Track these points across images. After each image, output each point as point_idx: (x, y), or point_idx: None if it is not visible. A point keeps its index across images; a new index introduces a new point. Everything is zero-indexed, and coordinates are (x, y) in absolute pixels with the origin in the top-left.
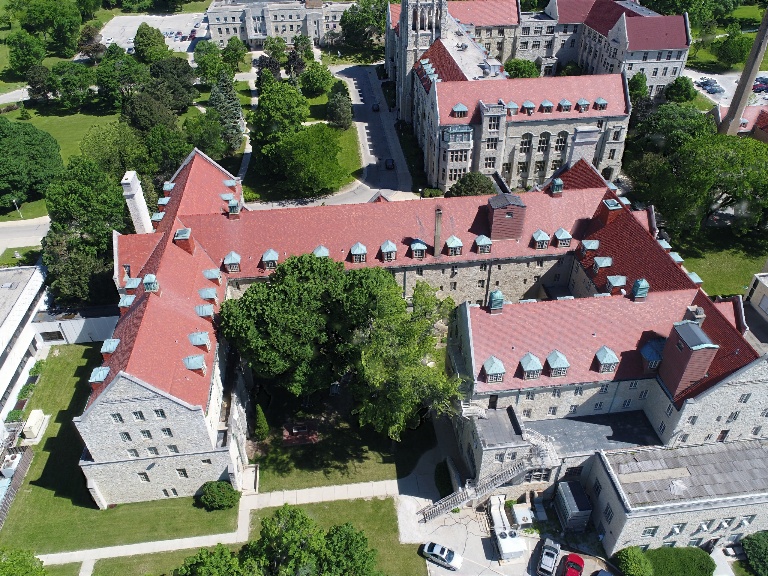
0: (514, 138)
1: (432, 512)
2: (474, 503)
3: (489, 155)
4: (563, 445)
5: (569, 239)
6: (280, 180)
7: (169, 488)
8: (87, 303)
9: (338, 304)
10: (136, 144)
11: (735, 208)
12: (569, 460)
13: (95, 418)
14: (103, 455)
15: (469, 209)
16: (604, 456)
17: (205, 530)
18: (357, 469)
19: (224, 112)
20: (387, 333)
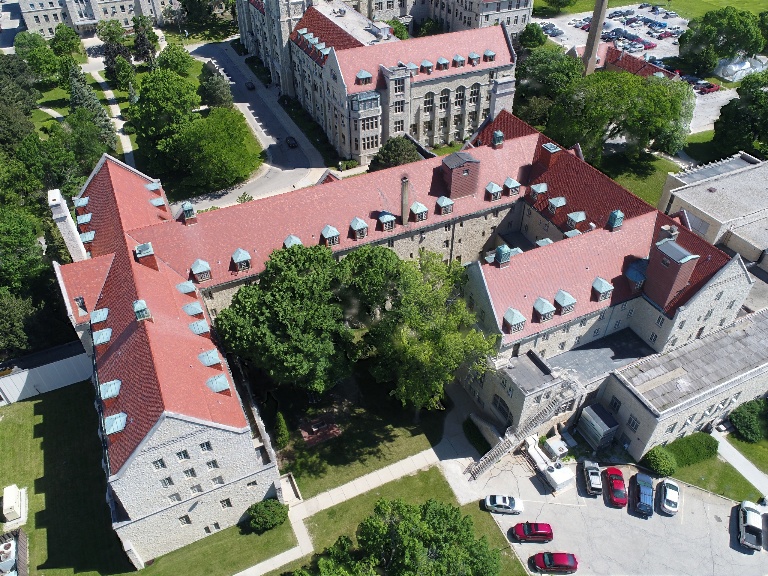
0: (418, 99)
1: (479, 468)
2: (512, 449)
3: (397, 119)
4: (580, 374)
5: (518, 186)
6: (180, 176)
7: (211, 524)
8: (23, 352)
9: (352, 289)
10: (3, 160)
11: (626, 136)
12: (590, 386)
13: (134, 471)
14: (141, 510)
15: (425, 173)
16: (620, 374)
17: (265, 554)
18: (391, 449)
19: (91, 110)
20: (417, 307)
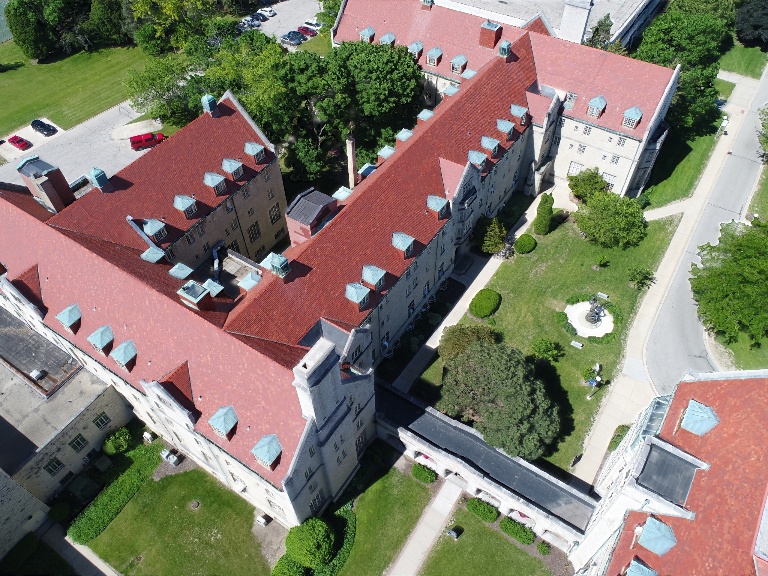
0: None
1: None
2: None
3: None
4: None
5: None
6: None
7: None
8: None
9: None
10: None
11: None
12: None
13: None
14: None
15: None
16: None
17: None
18: None
19: None
20: None
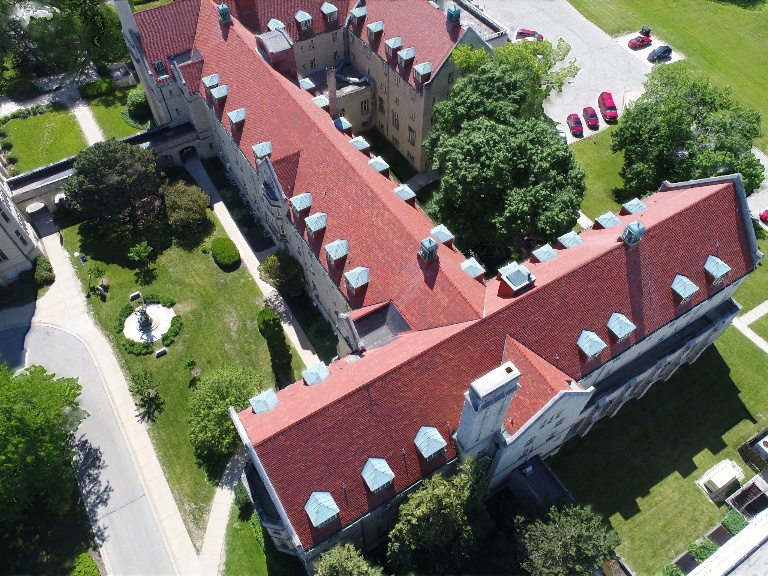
0: None
1: None
2: None
3: None
4: None
5: None
6: None
7: None
8: None
9: None
10: None
11: None
12: None
13: None
14: None
15: None
16: None
17: None
18: None
19: None
20: None
